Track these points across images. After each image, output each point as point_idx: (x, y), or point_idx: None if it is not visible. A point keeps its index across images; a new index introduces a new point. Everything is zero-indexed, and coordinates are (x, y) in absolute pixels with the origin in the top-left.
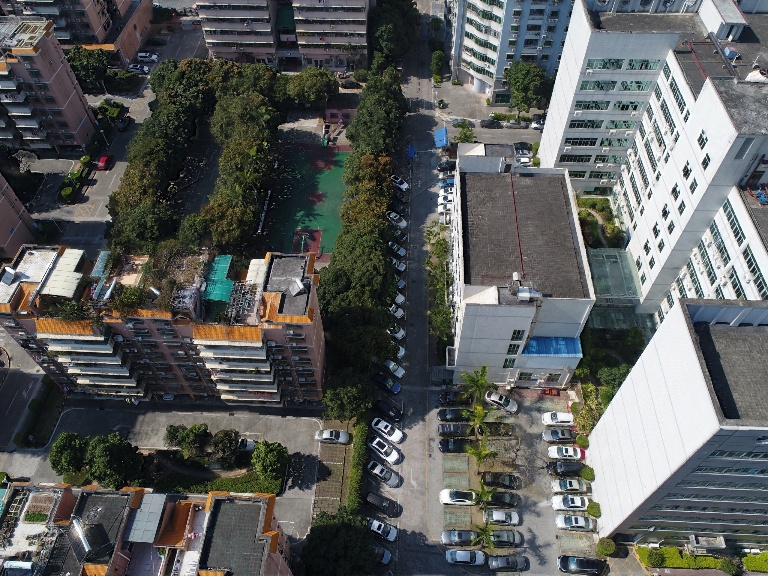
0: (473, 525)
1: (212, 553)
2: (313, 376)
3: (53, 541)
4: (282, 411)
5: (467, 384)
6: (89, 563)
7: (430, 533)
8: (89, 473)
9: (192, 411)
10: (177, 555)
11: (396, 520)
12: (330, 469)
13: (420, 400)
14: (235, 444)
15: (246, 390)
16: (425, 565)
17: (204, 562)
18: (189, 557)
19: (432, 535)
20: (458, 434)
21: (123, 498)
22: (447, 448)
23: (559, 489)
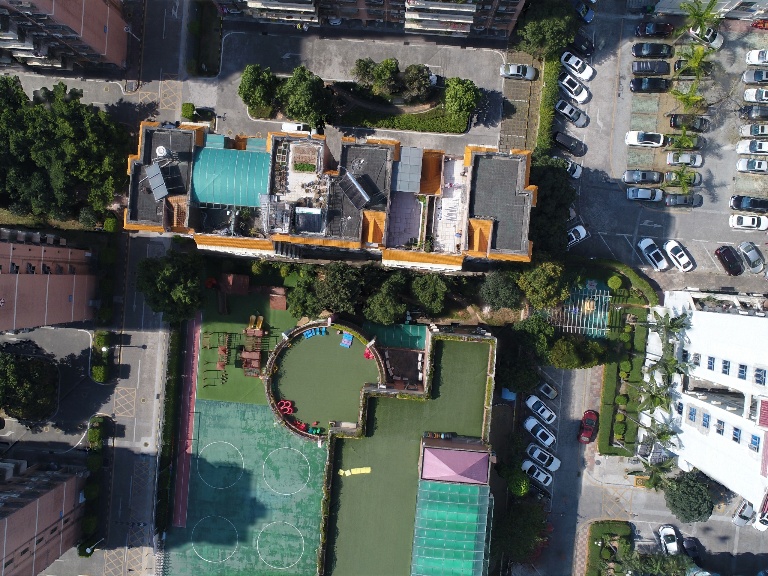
0: (655, 165)
1: (477, 204)
2: (517, 5)
3: (327, 189)
4: (461, 41)
5: (670, 13)
6: (368, 210)
7: (612, 172)
8: (287, 109)
9: (363, 38)
10: (440, 203)
11: (580, 159)
12: (515, 107)
13: (613, 31)
14: (430, 82)
15: (438, 20)
16: (605, 200)
17: (471, 211)
18: (445, 203)
19: (614, 173)
20: (653, 73)
21: (382, 151)
22: (640, 88)
23: (749, 134)
